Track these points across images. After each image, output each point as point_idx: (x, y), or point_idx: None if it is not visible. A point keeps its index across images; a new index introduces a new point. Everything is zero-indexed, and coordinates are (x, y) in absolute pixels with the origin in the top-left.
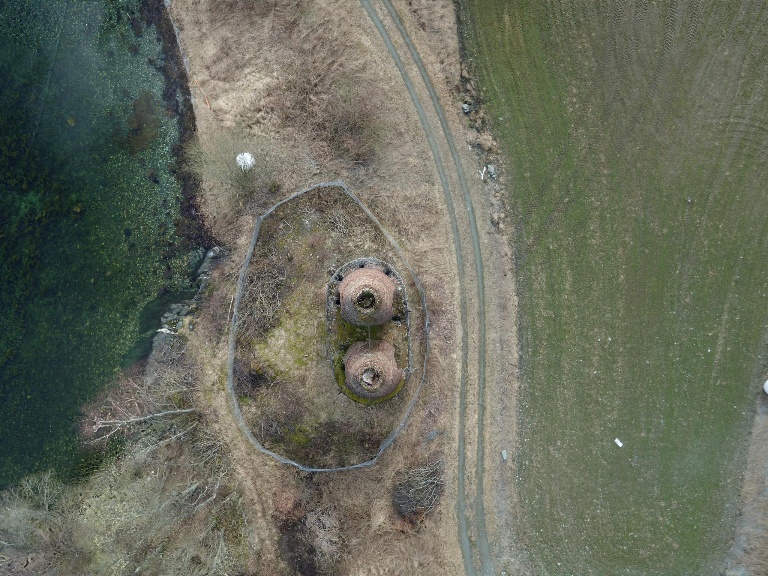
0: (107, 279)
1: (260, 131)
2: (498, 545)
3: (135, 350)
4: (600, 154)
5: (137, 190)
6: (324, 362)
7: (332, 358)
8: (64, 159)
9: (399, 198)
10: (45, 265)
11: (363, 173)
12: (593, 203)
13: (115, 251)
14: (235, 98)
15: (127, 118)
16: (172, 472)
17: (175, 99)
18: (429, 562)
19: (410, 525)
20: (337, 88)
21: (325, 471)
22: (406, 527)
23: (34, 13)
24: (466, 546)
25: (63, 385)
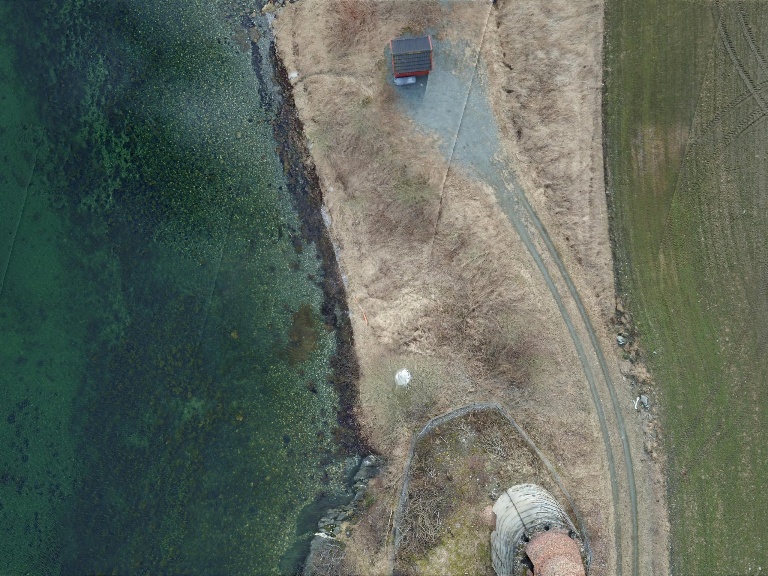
0: (266, 483)
1: (416, 348)
2: None
3: (292, 551)
4: (752, 392)
5: (296, 399)
6: None
7: None
8: (226, 368)
9: (555, 424)
10: (207, 468)
11: (518, 395)
12: (745, 438)
13: (274, 456)
14: (392, 316)
15: (287, 330)
16: None
17: (333, 313)
18: None
19: None
20: (494, 314)
21: None
22: None
23: (199, 228)
24: None
25: None
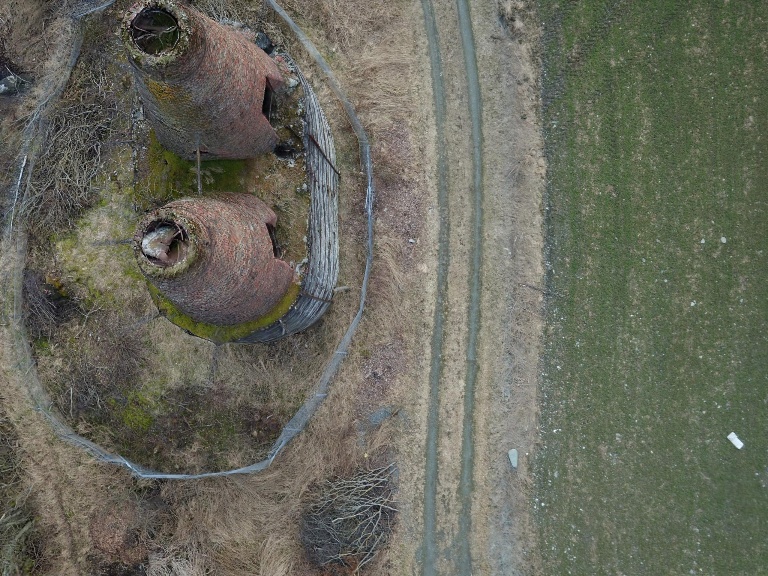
0: None
1: None
2: None
3: None
4: None
5: None
6: None
7: None
8: None
9: None
10: None
11: None
12: None
13: None
14: None
15: None
16: None
17: None
18: None
19: None
20: None
21: (181, 478)
22: None
23: None
24: None
25: None
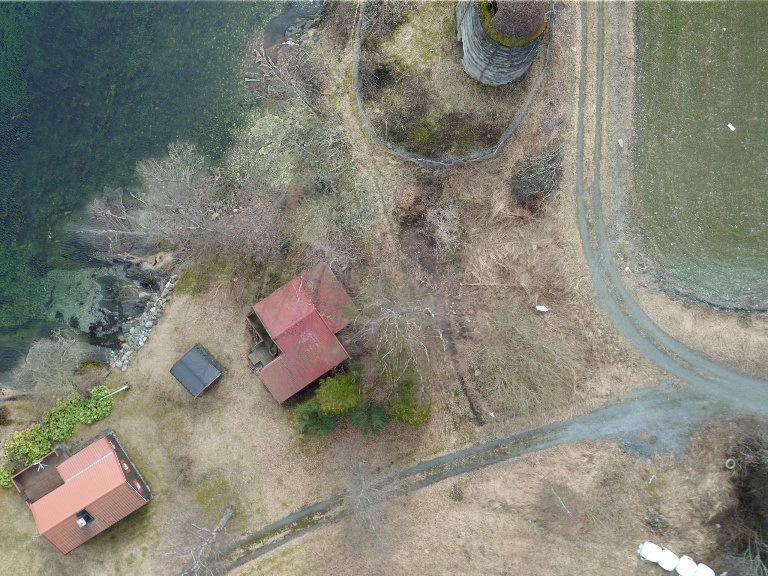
0: None
1: None
2: (614, 228)
3: None
4: None
5: None
6: (449, 56)
7: (478, 1)
8: None
9: None
10: None
11: None
12: None
13: None
14: None
15: None
16: (296, 174)
17: None
18: (547, 244)
19: (529, 212)
20: None
21: (446, 166)
22: (525, 213)
23: None
24: (584, 228)
25: (190, 97)
